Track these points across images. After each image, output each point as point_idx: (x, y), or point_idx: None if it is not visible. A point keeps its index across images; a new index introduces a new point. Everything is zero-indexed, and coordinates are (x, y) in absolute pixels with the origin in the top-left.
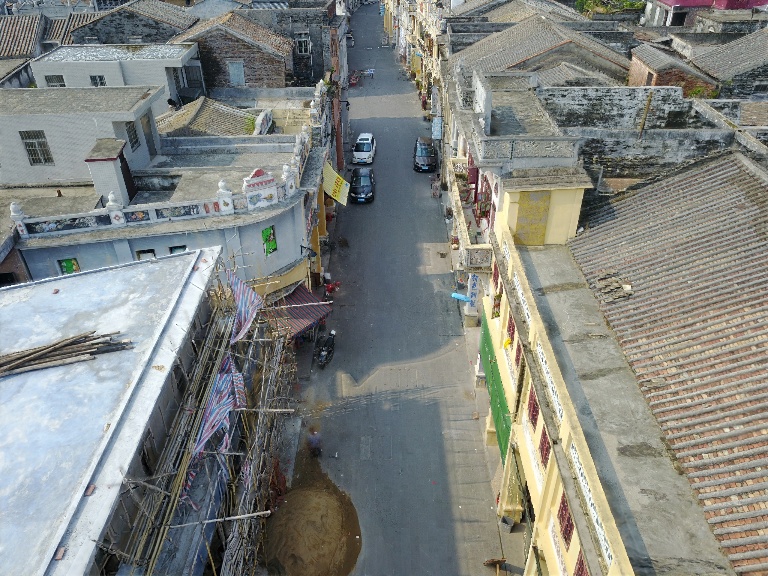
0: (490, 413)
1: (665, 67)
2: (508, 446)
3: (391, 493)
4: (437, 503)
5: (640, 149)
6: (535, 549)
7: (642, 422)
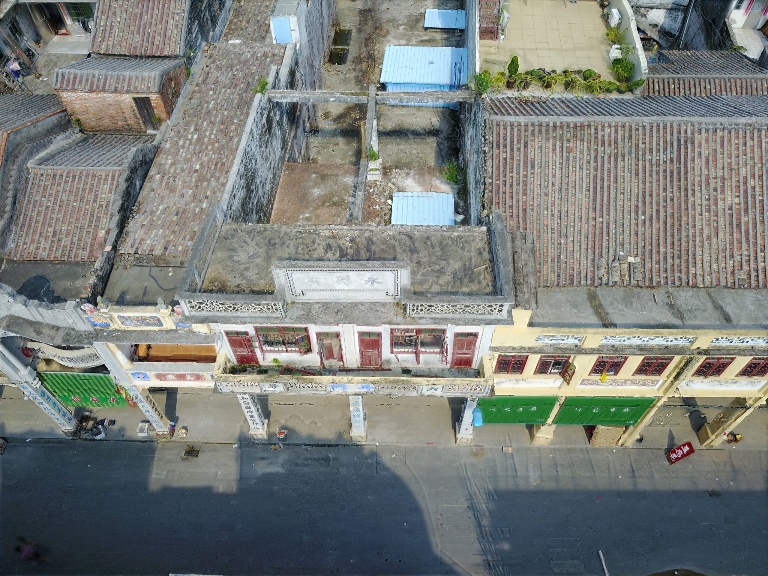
0: (552, 428)
1: (159, 82)
2: (654, 410)
3: (621, 540)
4: (621, 497)
5: (269, 172)
6: (759, 407)
7: (767, 297)
